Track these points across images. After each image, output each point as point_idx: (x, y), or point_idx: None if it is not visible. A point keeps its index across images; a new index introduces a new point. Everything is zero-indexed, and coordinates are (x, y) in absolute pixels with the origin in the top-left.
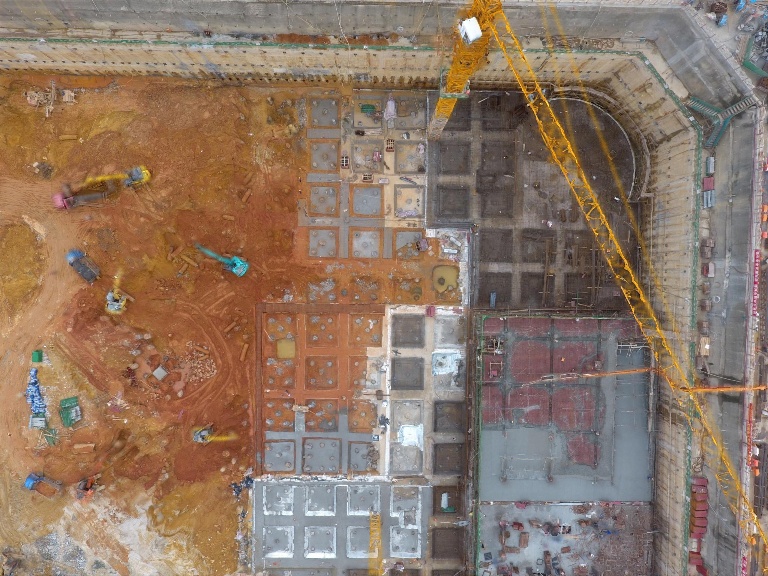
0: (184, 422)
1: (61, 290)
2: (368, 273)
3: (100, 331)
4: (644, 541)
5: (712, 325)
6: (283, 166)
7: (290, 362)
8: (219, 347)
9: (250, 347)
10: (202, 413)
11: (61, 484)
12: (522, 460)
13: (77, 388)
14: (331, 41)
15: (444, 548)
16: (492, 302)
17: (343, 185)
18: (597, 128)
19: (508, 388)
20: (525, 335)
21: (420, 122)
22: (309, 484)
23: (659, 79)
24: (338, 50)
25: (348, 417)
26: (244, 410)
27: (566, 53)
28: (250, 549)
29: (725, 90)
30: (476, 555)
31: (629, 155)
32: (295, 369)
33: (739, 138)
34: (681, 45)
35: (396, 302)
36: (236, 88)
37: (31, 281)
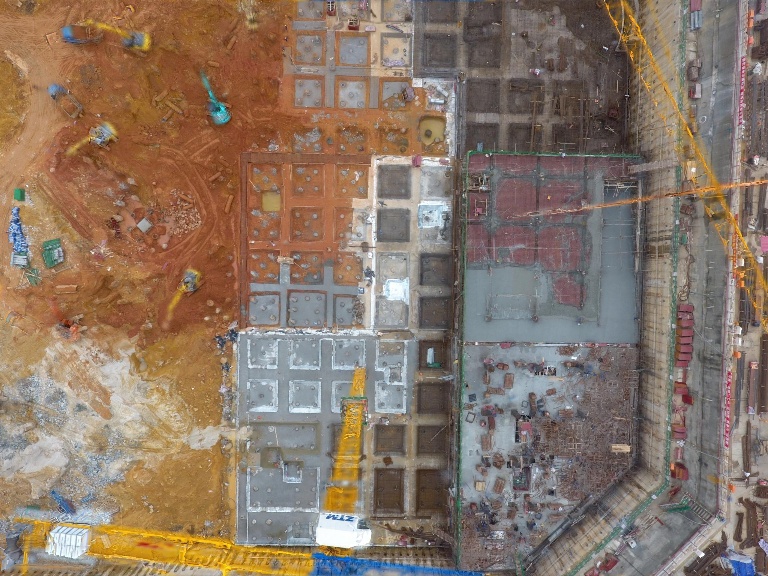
0: (168, 273)
1: (44, 128)
2: (354, 123)
3: (83, 174)
4: (630, 378)
5: (699, 147)
6: (269, 13)
7: (275, 214)
8: (204, 197)
9: (235, 199)
10: (186, 265)
11: (43, 324)
12: (507, 300)
13: (60, 230)
14: None
15: (430, 405)
16: None
17: (329, 33)
18: None
19: (493, 226)
20: (511, 173)
21: None
22: (294, 337)
23: None
24: None
25: (333, 270)
26: (229, 263)
27: None
28: (234, 404)
29: None
30: (461, 397)
31: (618, 3)
32: (280, 220)
33: None
34: None
35: (382, 153)
36: None
37: (14, 119)
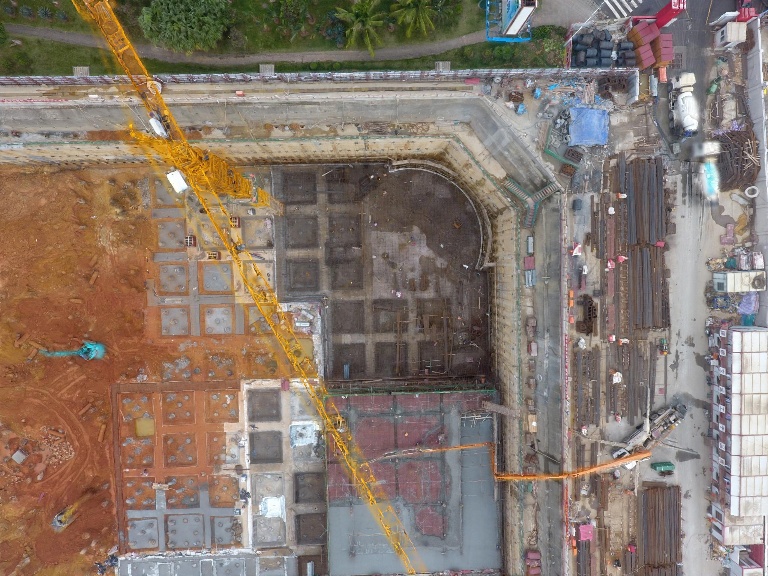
0: (44, 505)
1: None
2: (221, 349)
3: None
4: None
5: (538, 403)
6: (129, 247)
7: (149, 440)
8: (75, 429)
9: (108, 427)
10: (63, 495)
11: None
12: None
13: None
14: (143, 136)
15: None
16: (346, 374)
17: (191, 263)
18: (443, 196)
19: (353, 465)
20: (368, 412)
21: None
22: (174, 560)
23: (475, 161)
24: (151, 144)
25: (209, 492)
26: (105, 490)
27: (381, 139)
28: None
29: (533, 175)
30: None
31: (476, 222)
32: (153, 448)
33: (550, 221)
34: (489, 130)
35: (251, 377)
36: (73, 173)
37: None
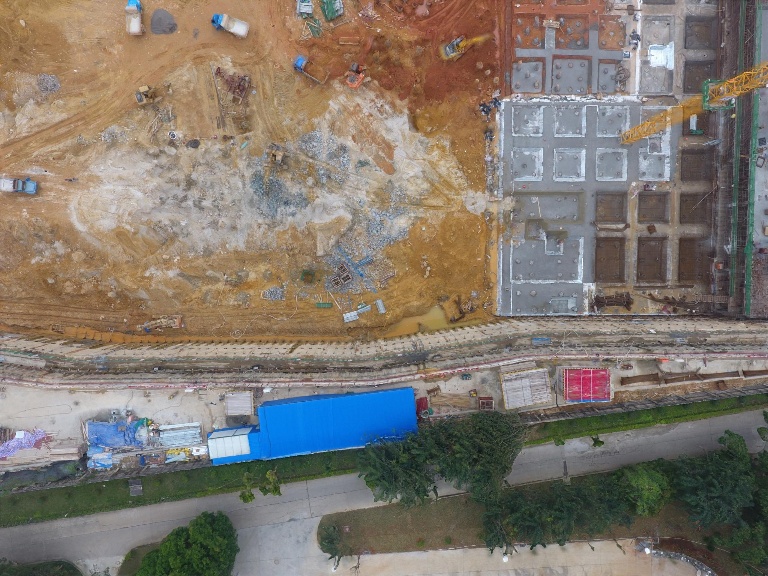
0: (432, 39)
1: None
2: None
3: None
4: None
5: None
6: None
7: None
8: None
9: None
10: (450, 31)
11: None
12: None
13: None
14: None
15: (690, 174)
16: None
17: None
18: None
19: None
20: None
21: None
22: (558, 105)
23: None
24: None
25: (598, 34)
26: (491, 29)
27: None
28: (496, 175)
29: None
30: (749, 142)
31: None
32: None
33: None
34: None
35: None
36: None
37: None
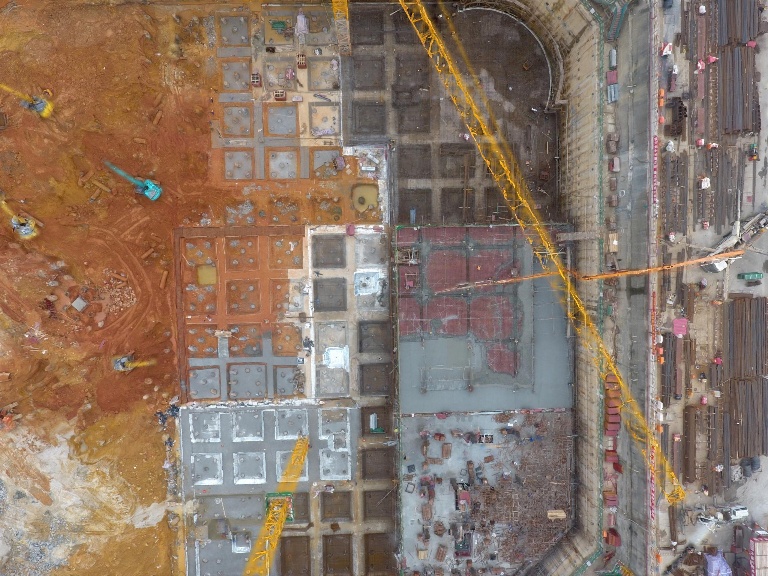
0: (105, 352)
1: None
2: (286, 194)
3: (11, 259)
4: (564, 445)
5: (619, 220)
6: (193, 86)
7: (211, 288)
8: (137, 274)
9: (170, 274)
10: (124, 342)
11: None
12: (442, 371)
13: None
14: None
15: (375, 470)
16: (412, 219)
17: (256, 104)
18: (512, 38)
19: (425, 299)
20: (440, 245)
21: (332, 38)
22: (236, 410)
23: None
24: None
25: (272, 341)
26: (167, 338)
27: None
28: (180, 478)
29: None
30: (400, 468)
31: (545, 65)
32: (216, 294)
33: (637, 26)
34: None
35: (316, 223)
36: (139, 5)
37: None
